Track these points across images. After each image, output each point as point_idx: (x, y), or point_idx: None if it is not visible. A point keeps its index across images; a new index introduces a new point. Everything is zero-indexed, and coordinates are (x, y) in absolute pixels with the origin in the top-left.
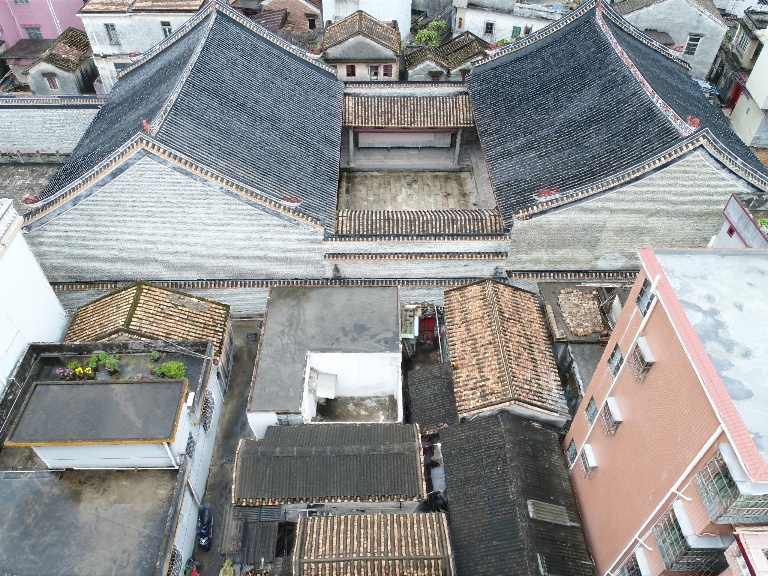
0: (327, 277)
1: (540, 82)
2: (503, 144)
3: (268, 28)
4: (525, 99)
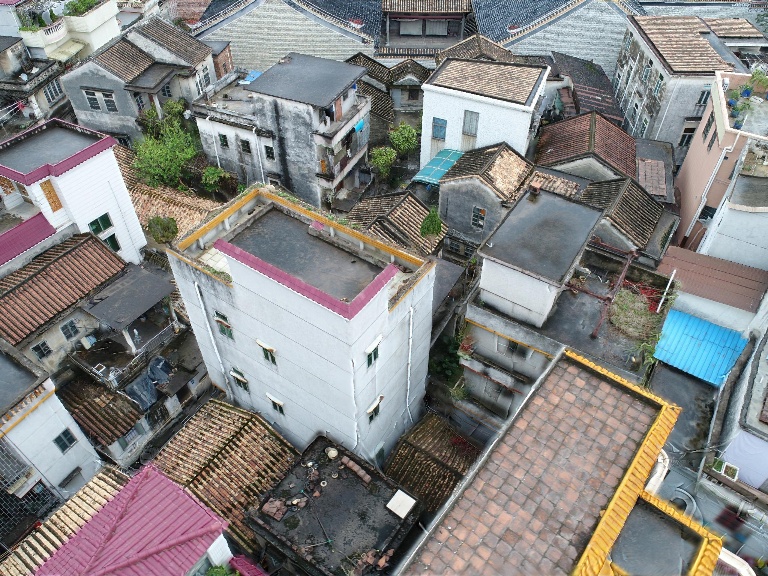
0: (470, 14)
1: (332, 6)
2: (370, 2)
3: (584, 83)
4: (346, 8)
